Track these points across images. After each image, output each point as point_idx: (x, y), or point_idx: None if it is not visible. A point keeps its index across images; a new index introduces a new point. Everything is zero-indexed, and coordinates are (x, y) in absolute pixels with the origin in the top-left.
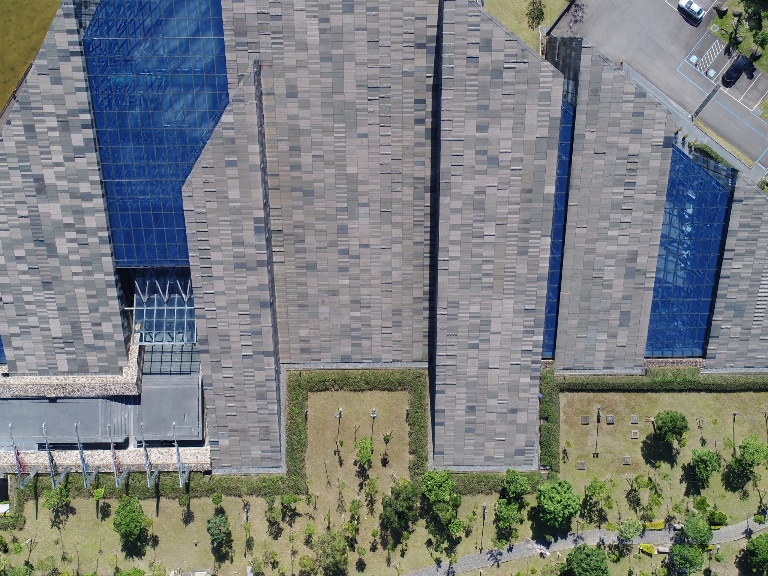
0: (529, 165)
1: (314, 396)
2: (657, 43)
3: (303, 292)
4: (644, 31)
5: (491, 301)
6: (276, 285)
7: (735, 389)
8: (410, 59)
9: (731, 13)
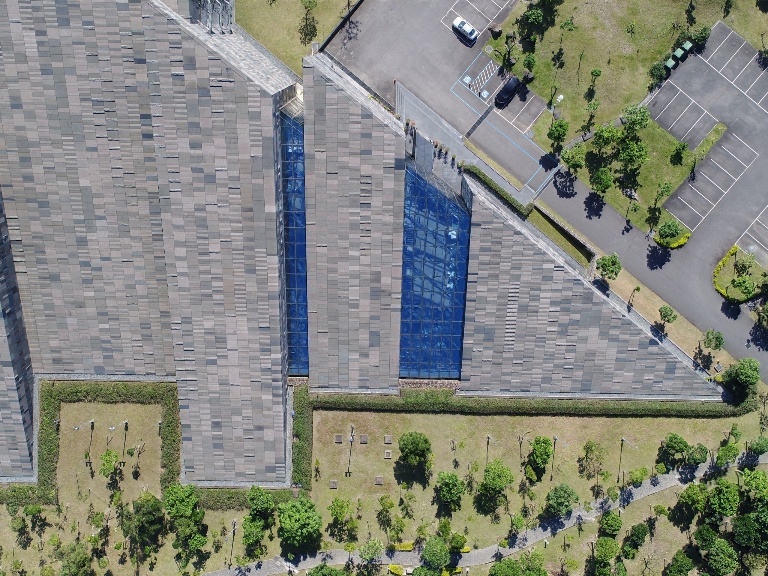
0: (247, 184)
1: (67, 407)
2: (431, 62)
3: (49, 303)
4: (418, 50)
5: (224, 318)
6: (21, 295)
7: (489, 412)
8: (131, 74)
9: (505, 35)
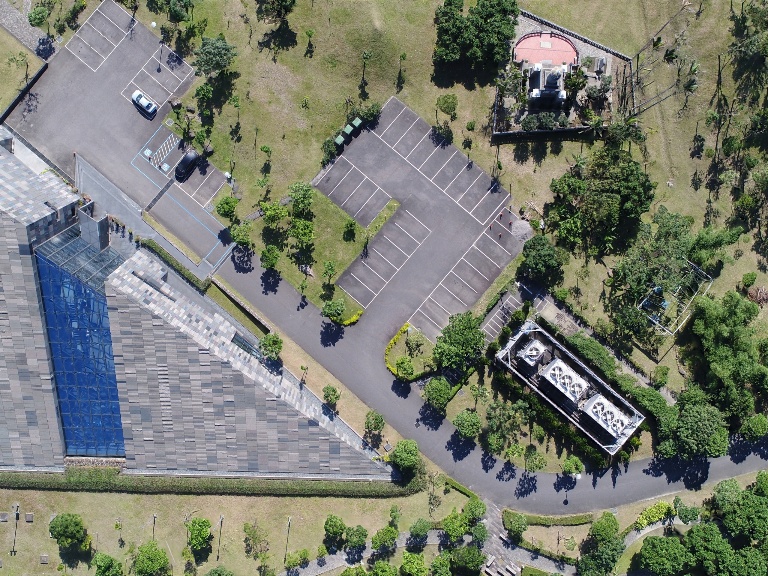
0: None
1: None
2: (111, 135)
3: None
4: (98, 123)
5: None
6: None
7: (154, 491)
8: None
9: None
